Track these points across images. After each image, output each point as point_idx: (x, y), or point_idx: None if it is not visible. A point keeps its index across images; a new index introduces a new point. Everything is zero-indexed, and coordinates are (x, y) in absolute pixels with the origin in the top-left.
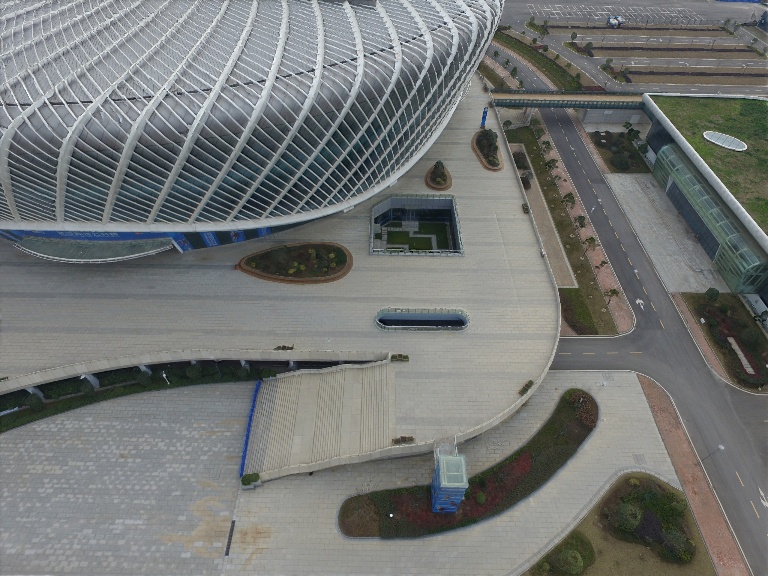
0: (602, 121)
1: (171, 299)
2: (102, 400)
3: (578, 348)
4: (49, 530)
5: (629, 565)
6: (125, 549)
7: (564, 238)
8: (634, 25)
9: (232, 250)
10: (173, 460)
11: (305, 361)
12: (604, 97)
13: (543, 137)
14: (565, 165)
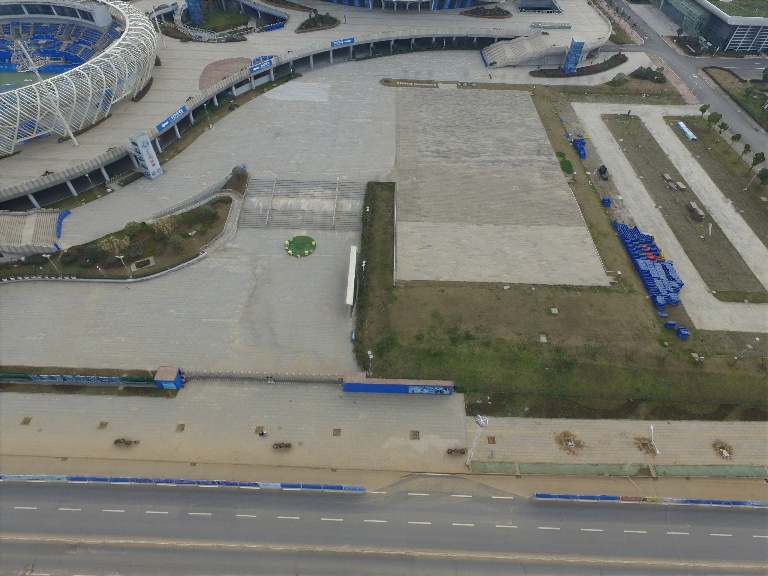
0: None
1: (438, 20)
2: (418, 51)
3: (618, 47)
4: (422, 73)
5: None
6: None
7: None
8: None
9: (454, 10)
10: None
11: (503, 38)
12: None
13: None
14: (605, 1)
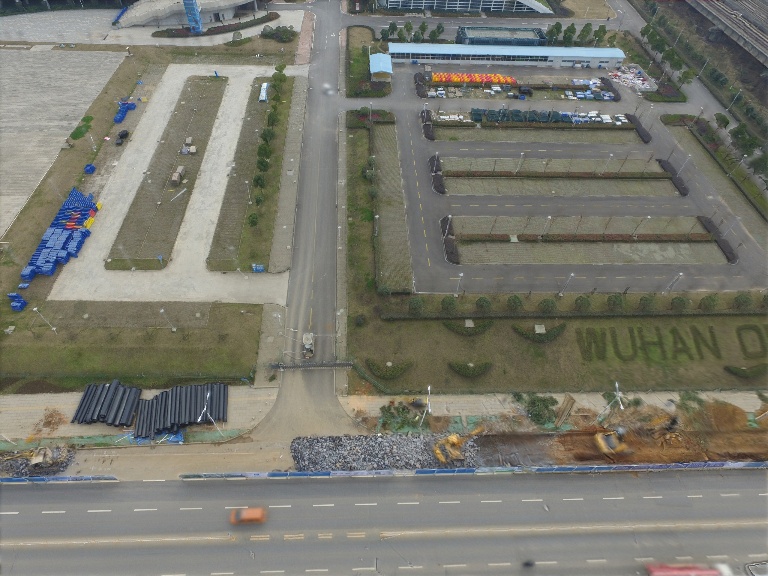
0: None
1: None
2: (51, 11)
3: (284, 6)
4: (30, 34)
5: (264, 42)
6: (62, 38)
7: None
8: None
9: None
10: (84, 23)
11: None
12: None
13: None
14: None
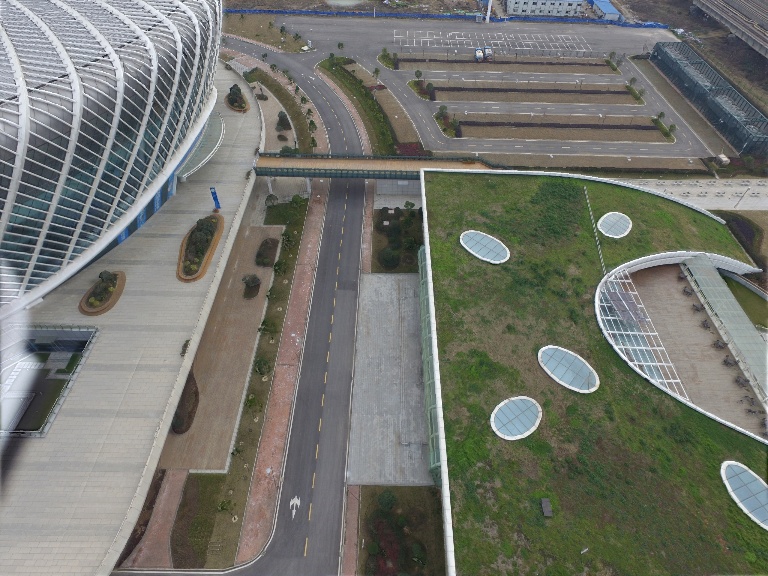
0: (399, 192)
1: None
2: None
3: None
4: None
5: None
6: None
7: (254, 382)
8: (506, 57)
9: None
10: None
11: None
12: (400, 163)
13: (314, 216)
14: (319, 259)
